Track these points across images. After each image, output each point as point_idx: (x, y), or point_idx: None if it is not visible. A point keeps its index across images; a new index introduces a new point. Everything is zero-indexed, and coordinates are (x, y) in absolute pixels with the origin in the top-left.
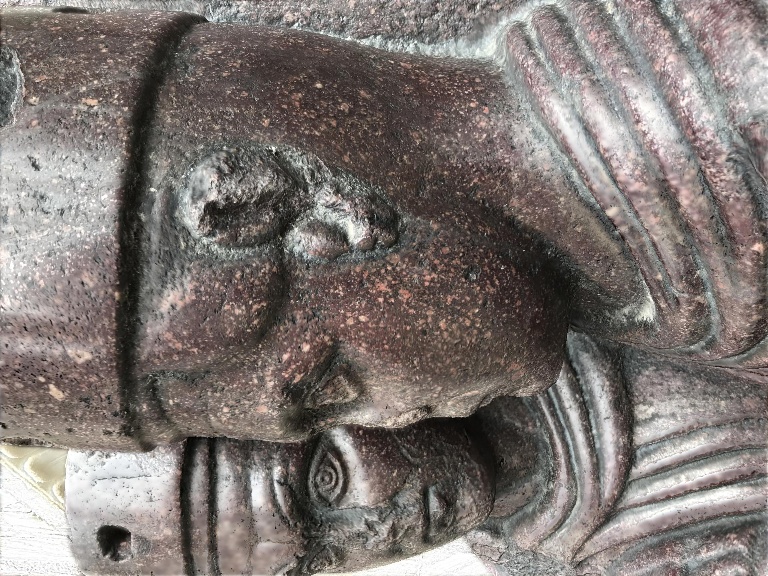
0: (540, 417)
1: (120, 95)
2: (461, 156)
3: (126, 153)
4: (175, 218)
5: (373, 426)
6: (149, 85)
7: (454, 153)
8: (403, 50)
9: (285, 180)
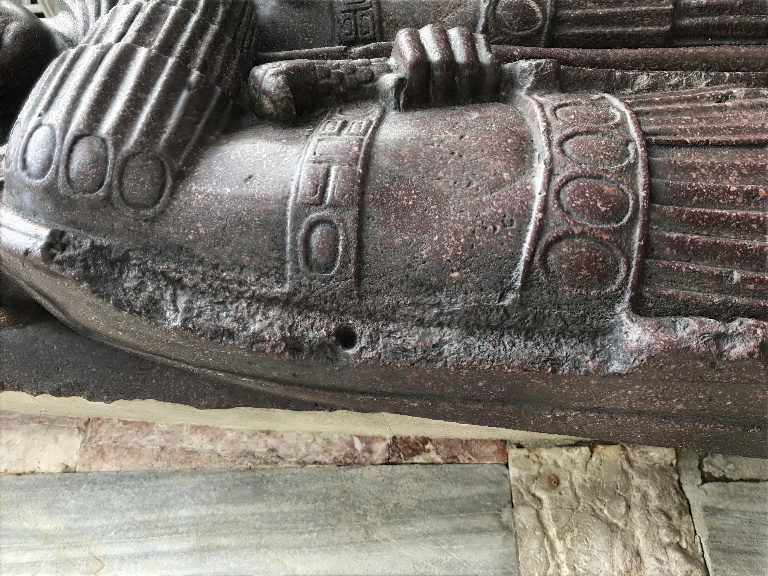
0: None
1: None
2: None
3: None
4: None
5: None
6: None
7: None
8: None
9: None
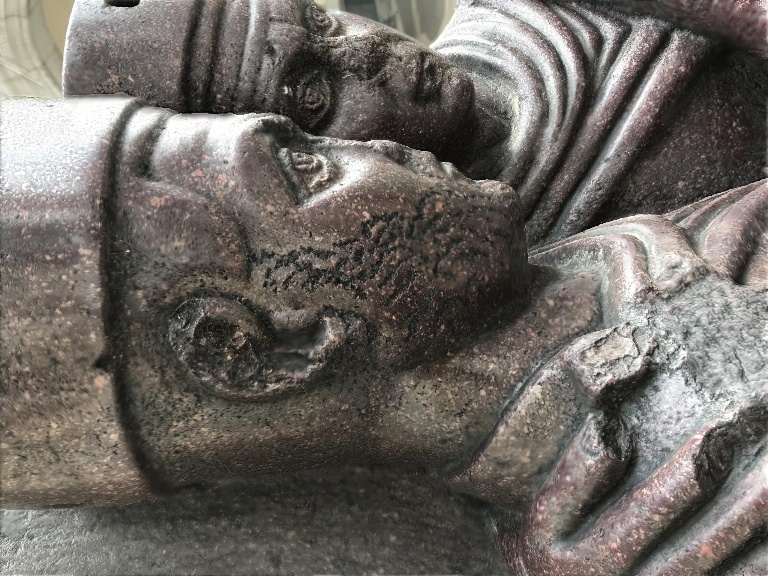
0: (549, 265)
1: None
2: None
3: None
4: None
5: (351, 49)
6: None
7: None
8: None
9: None
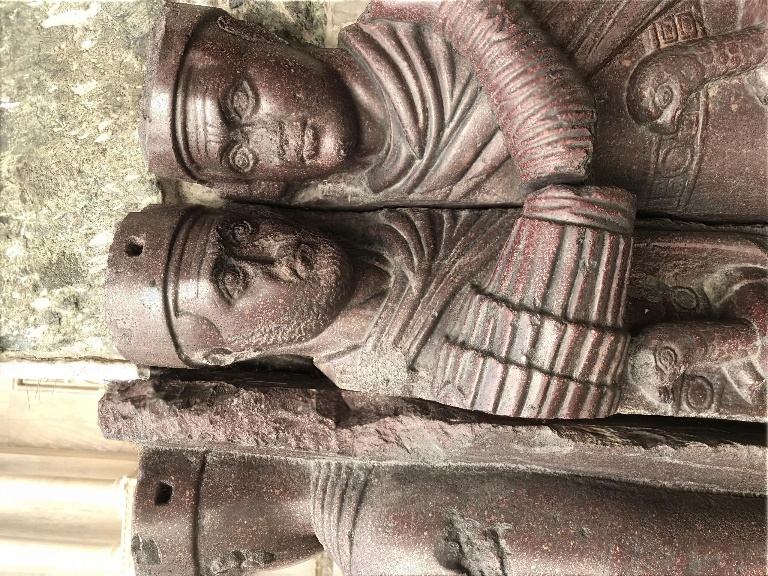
0: None
1: (188, 551)
2: (294, 530)
3: (193, 566)
4: (210, 571)
5: None
6: (194, 543)
7: (292, 530)
8: (280, 457)
9: (238, 562)
